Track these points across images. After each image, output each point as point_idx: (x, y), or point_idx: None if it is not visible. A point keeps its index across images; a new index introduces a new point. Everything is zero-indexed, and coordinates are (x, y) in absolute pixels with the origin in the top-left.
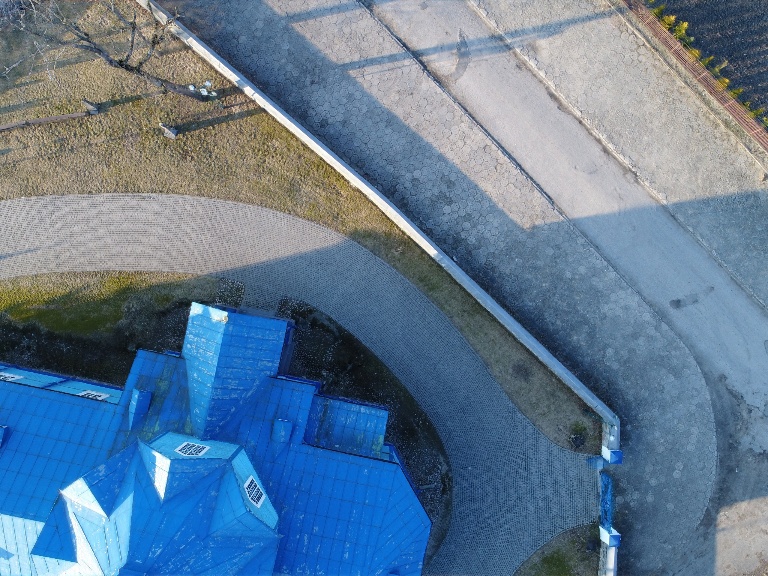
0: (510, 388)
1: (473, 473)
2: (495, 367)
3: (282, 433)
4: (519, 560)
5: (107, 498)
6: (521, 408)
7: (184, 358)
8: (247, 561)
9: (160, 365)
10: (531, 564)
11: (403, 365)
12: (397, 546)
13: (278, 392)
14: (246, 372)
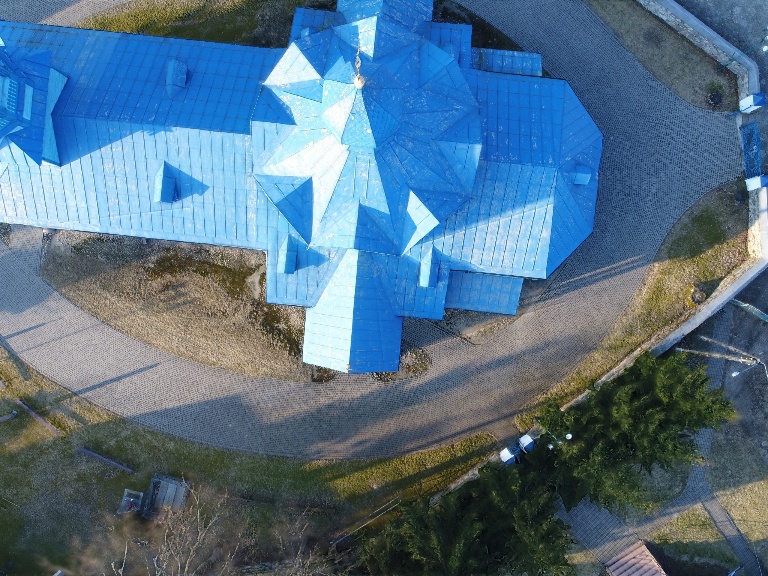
0: (643, 56)
1: (615, 142)
2: (626, 37)
3: (452, 55)
4: (669, 223)
5: (317, 63)
6: (656, 74)
7: (341, 12)
8: (455, 120)
9: (320, 18)
10: (681, 225)
11: (536, 44)
12: (578, 144)
13: (437, 32)
14: (407, 8)
